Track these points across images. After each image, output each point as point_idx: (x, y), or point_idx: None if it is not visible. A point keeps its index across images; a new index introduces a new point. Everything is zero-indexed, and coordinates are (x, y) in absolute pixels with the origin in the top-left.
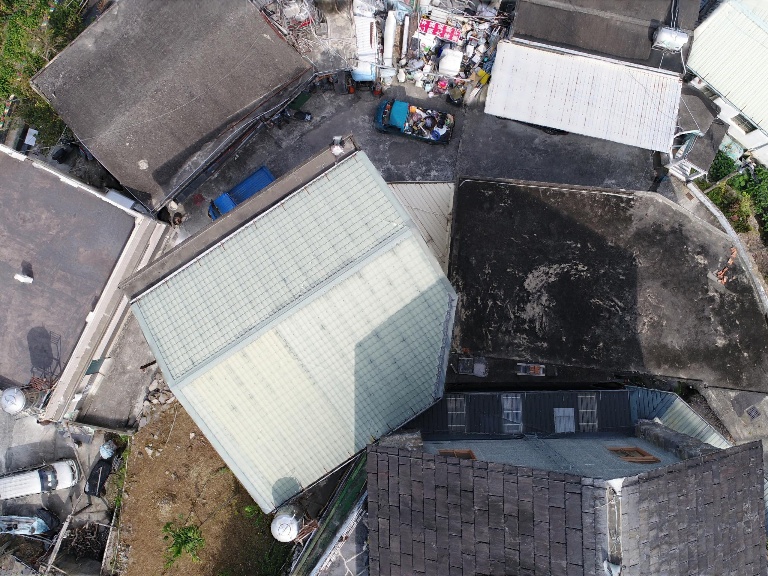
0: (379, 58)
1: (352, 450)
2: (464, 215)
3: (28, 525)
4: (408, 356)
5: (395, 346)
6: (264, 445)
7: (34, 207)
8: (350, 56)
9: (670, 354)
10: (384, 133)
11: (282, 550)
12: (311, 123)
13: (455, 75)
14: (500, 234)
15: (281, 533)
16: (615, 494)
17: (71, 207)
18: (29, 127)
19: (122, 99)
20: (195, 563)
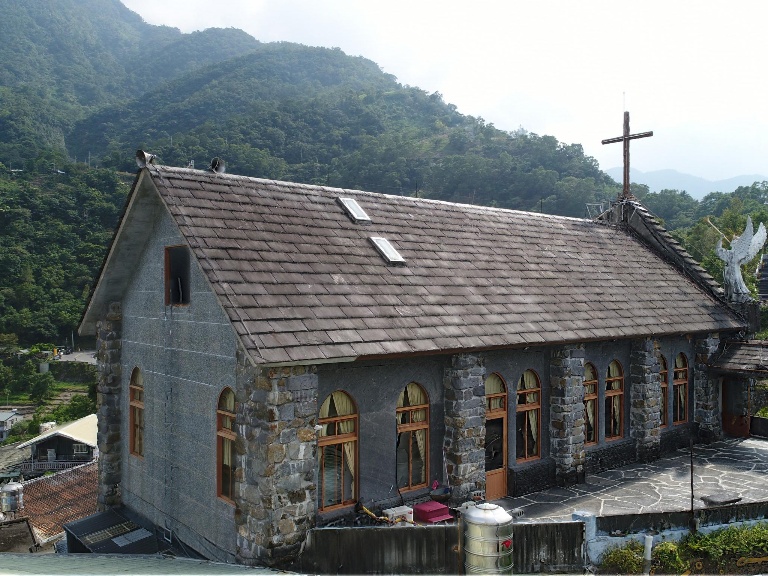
0: None
1: None
2: None
3: None
4: None
5: None
6: None
7: None
8: None
9: None
10: None
11: None
12: None
13: None
14: None
15: None
16: None
17: None
18: None
19: None
20: None
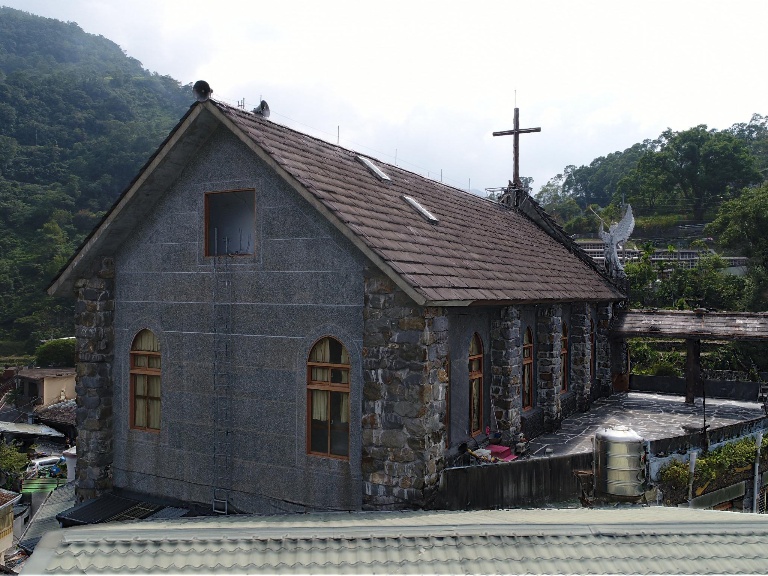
0: None
1: None
2: None
3: None
4: None
5: None
6: None
7: None
8: None
9: None
10: None
11: None
12: None
13: None
14: None
15: None
16: None
17: None
18: None
19: None
20: None
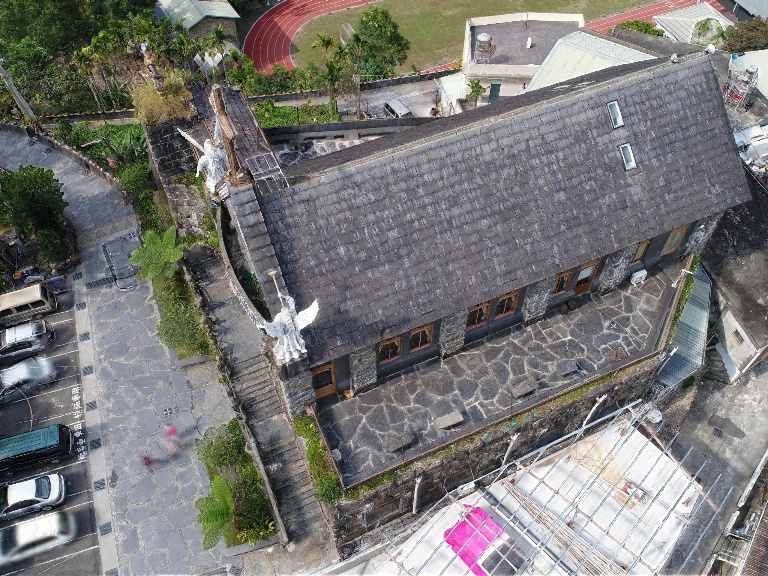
0: None
1: None
2: None
3: None
4: None
5: None
6: None
7: None
8: (740, 125)
9: (730, 278)
10: None
11: None
12: None
13: None
14: None
15: (525, 90)
16: None
17: None
18: None
19: None
20: None
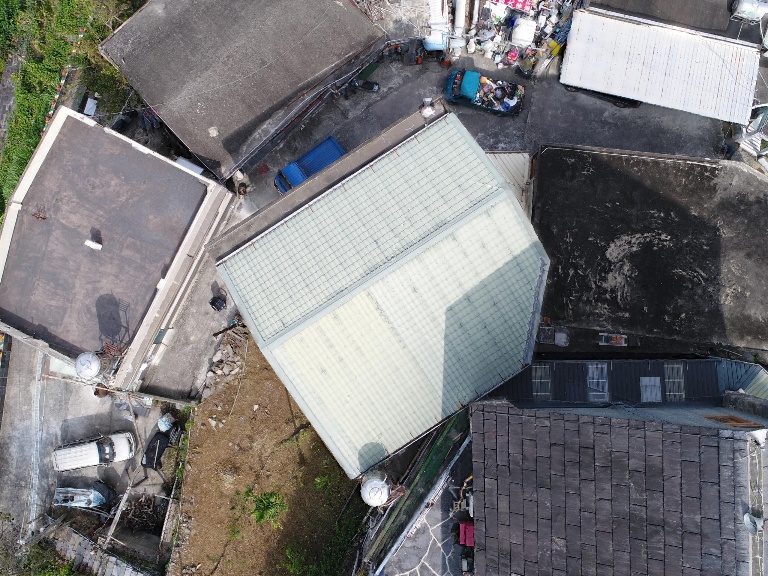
0: (449, 28)
1: (439, 416)
2: (546, 183)
3: (84, 497)
4: (498, 321)
5: (486, 310)
6: (352, 409)
7: (103, 173)
8: (423, 24)
9: (753, 326)
10: (452, 104)
11: (353, 521)
12: (378, 94)
13: (528, 45)
14: (582, 202)
15: (372, 497)
16: (758, 446)
17: (141, 174)
18: (88, 97)
19: (193, 65)
20: (259, 535)
